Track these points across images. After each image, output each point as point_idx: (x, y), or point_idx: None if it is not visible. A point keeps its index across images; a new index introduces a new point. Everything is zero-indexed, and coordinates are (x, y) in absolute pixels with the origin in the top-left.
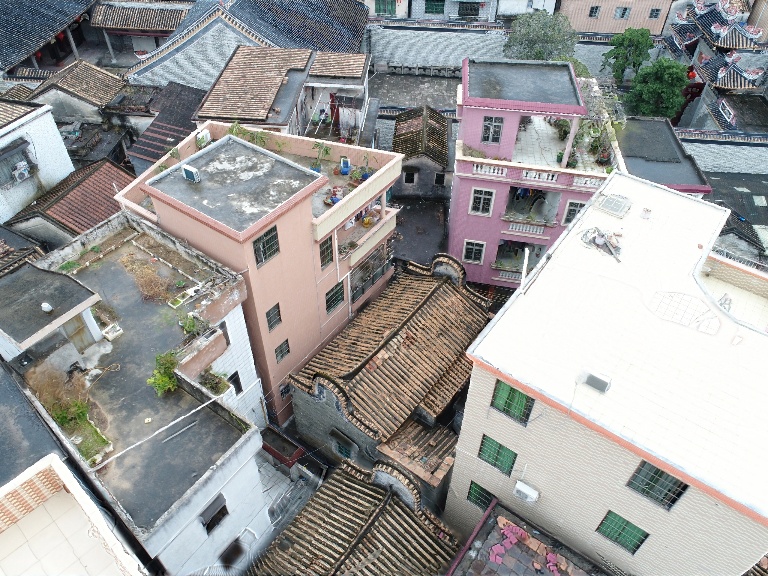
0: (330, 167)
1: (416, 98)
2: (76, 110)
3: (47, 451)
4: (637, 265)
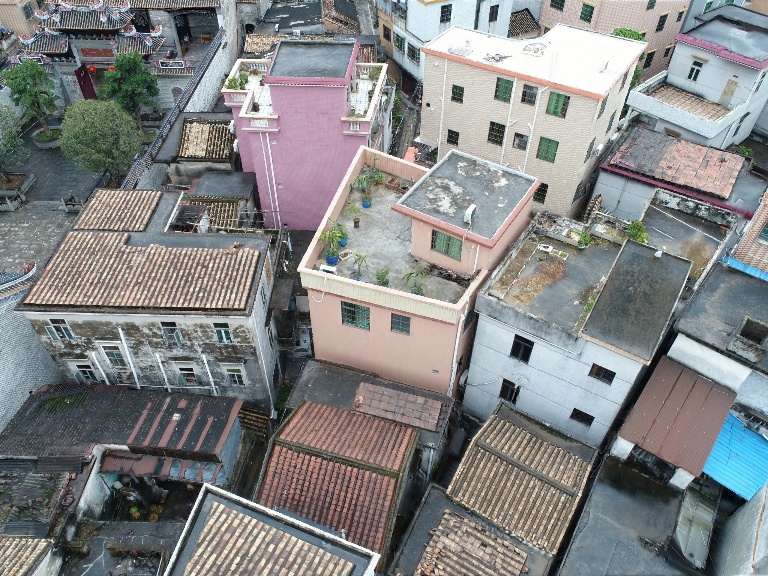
0: (358, 198)
1: None
2: None
3: (719, 274)
4: None
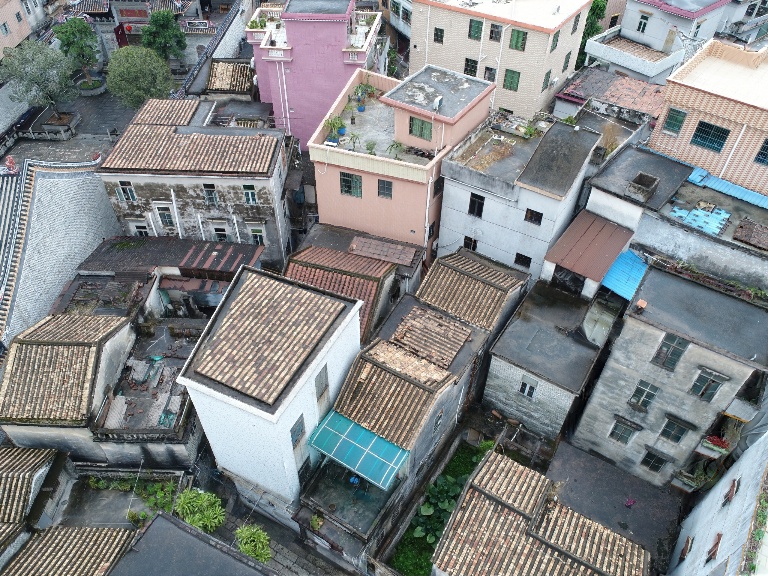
0: (354, 105)
1: None
2: (119, 351)
3: (629, 152)
4: (483, 0)
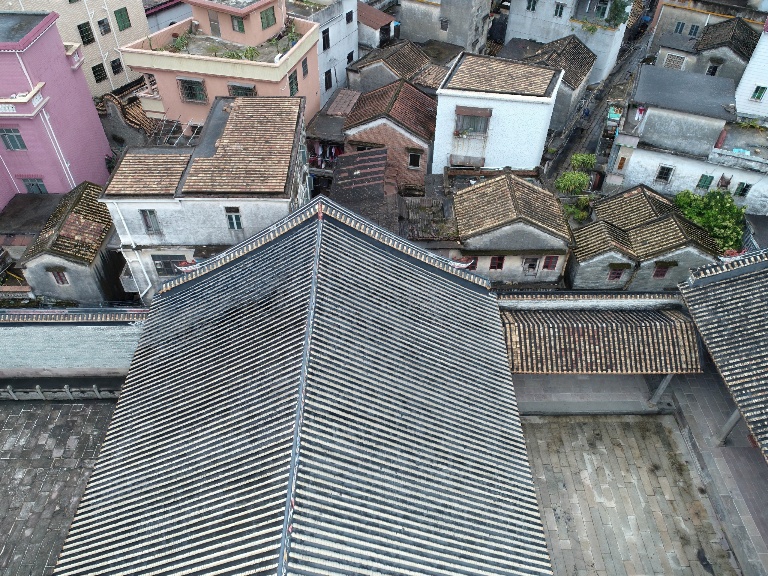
0: None
1: (0, 555)
2: None
3: None
4: None
